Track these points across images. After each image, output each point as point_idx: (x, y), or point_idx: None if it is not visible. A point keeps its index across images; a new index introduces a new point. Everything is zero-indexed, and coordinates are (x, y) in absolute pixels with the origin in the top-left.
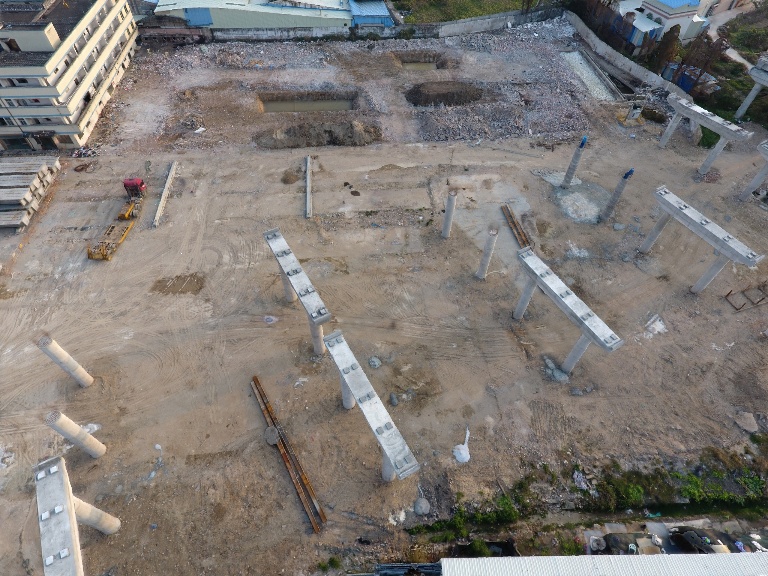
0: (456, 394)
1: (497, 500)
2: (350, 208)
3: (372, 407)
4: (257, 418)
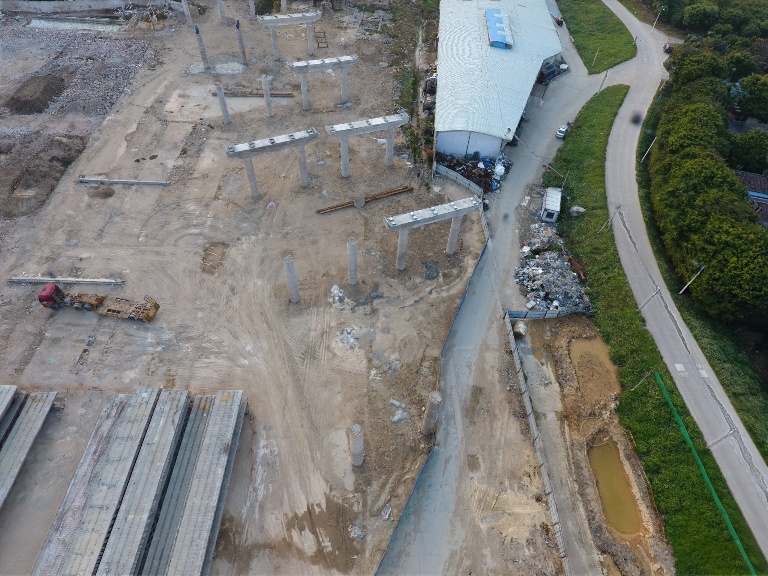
0: (350, 138)
1: (406, 134)
2: (171, 161)
3: (374, 122)
4: (346, 211)
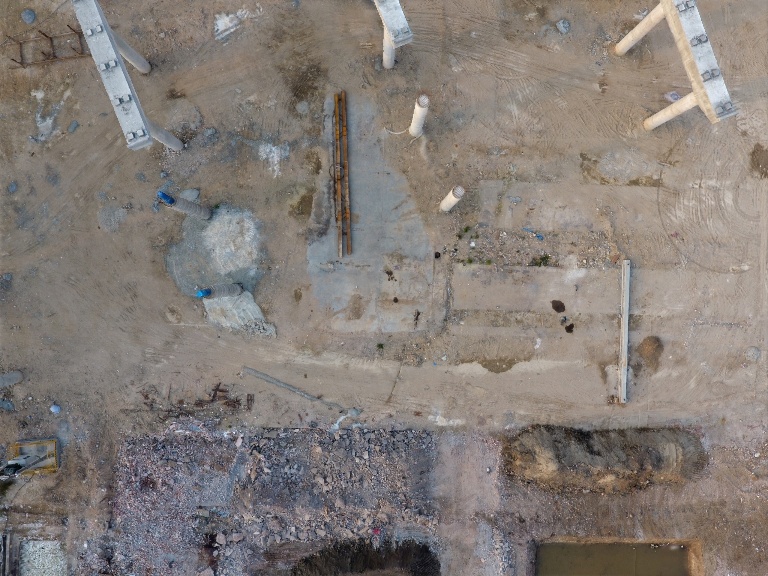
0: None
1: None
2: (569, 275)
3: None
4: None
